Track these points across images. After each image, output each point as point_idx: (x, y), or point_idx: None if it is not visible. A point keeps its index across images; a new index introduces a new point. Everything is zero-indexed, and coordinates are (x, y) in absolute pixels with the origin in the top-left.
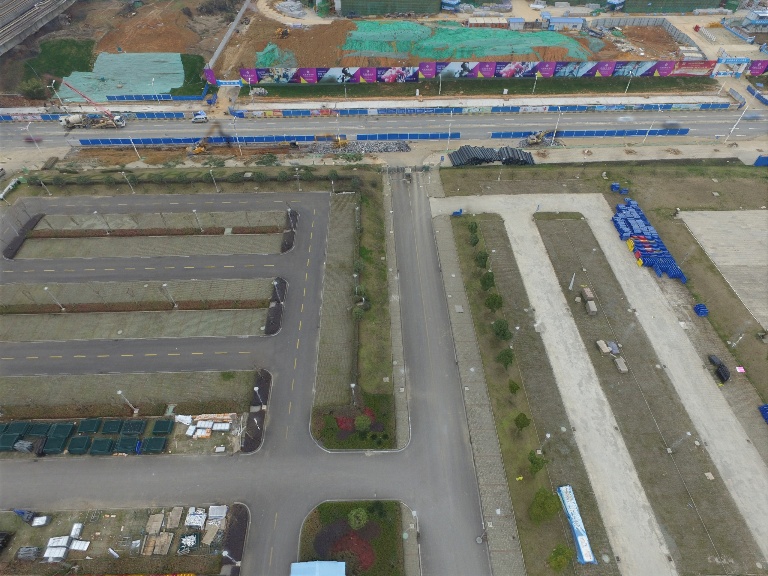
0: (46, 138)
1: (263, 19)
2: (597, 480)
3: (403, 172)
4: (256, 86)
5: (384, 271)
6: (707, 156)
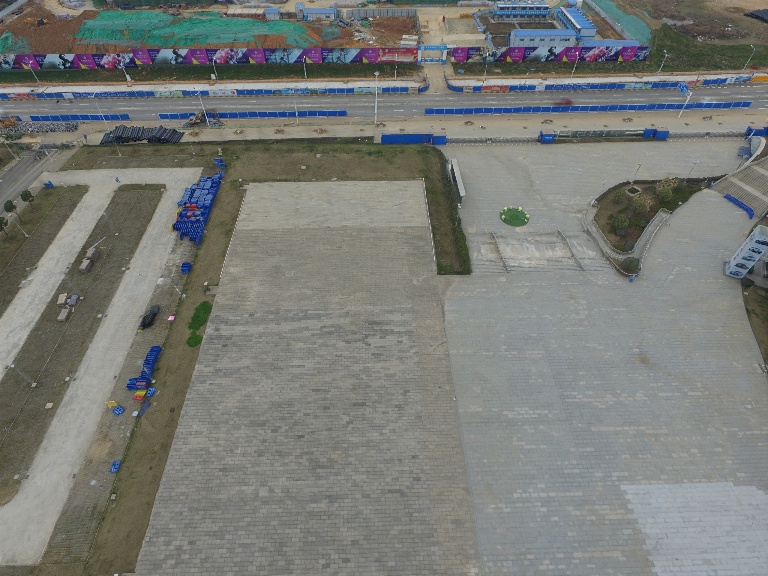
0: None
1: (38, 10)
2: None
3: (44, 149)
4: None
5: None
6: (347, 135)
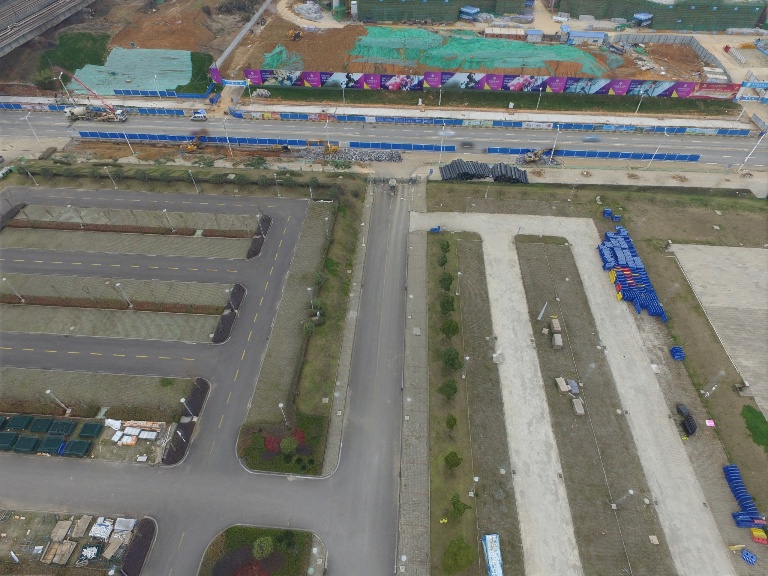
0: (50, 128)
1: (279, 20)
2: (528, 531)
3: None
4: (260, 87)
5: (347, 285)
6: (716, 185)
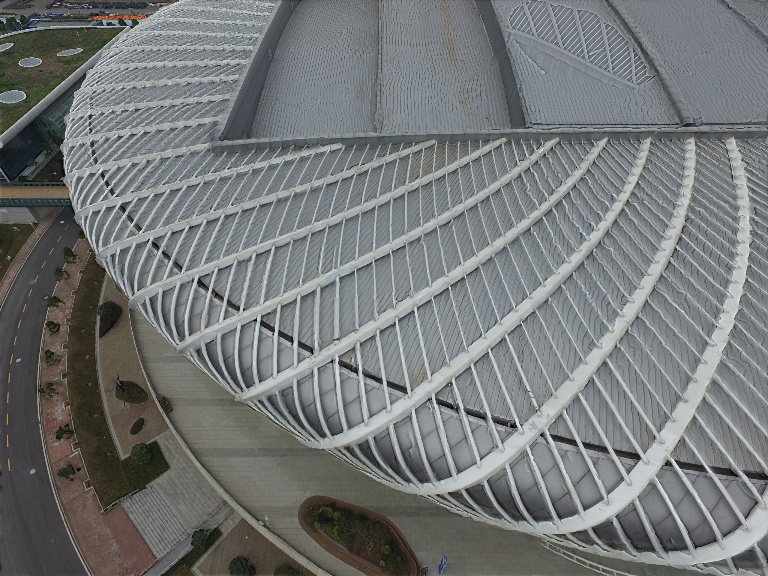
0: None
1: None
2: None
3: None
4: None
5: None
6: None
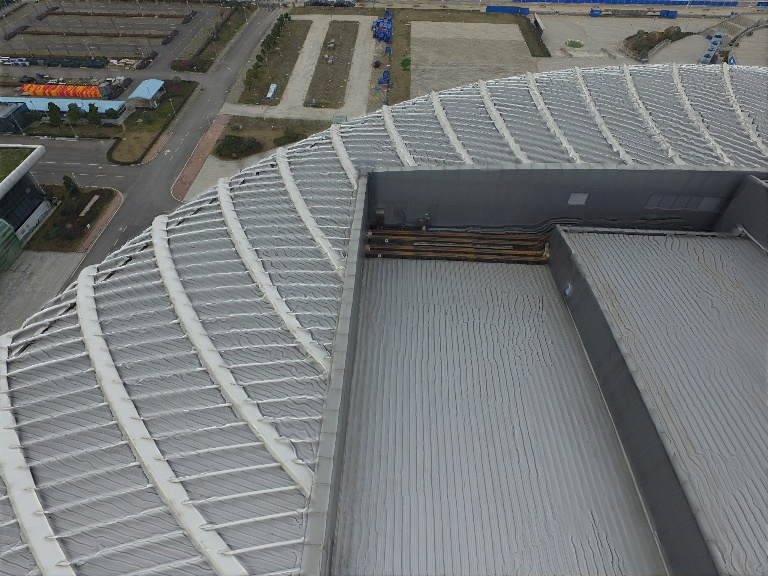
0: None
1: None
2: (290, 85)
3: None
4: None
5: (234, 33)
6: (462, 9)
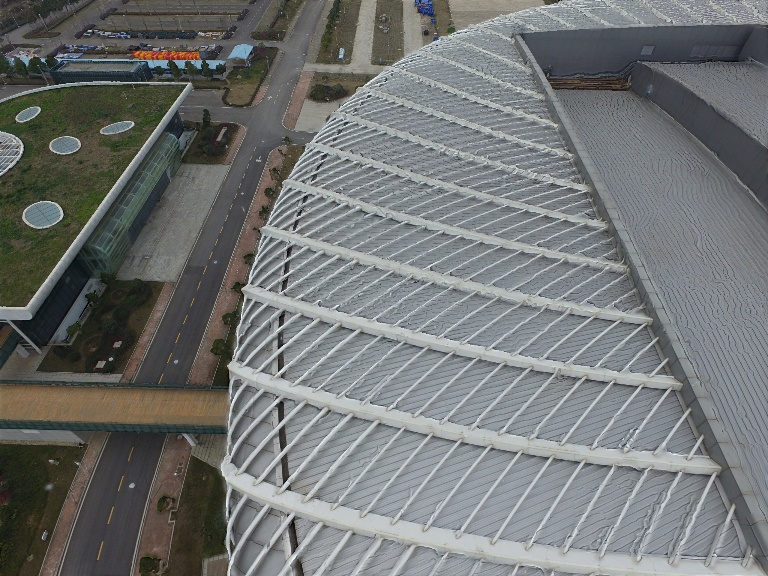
0: None
1: None
2: (356, 49)
3: None
4: None
5: (295, 11)
6: None
